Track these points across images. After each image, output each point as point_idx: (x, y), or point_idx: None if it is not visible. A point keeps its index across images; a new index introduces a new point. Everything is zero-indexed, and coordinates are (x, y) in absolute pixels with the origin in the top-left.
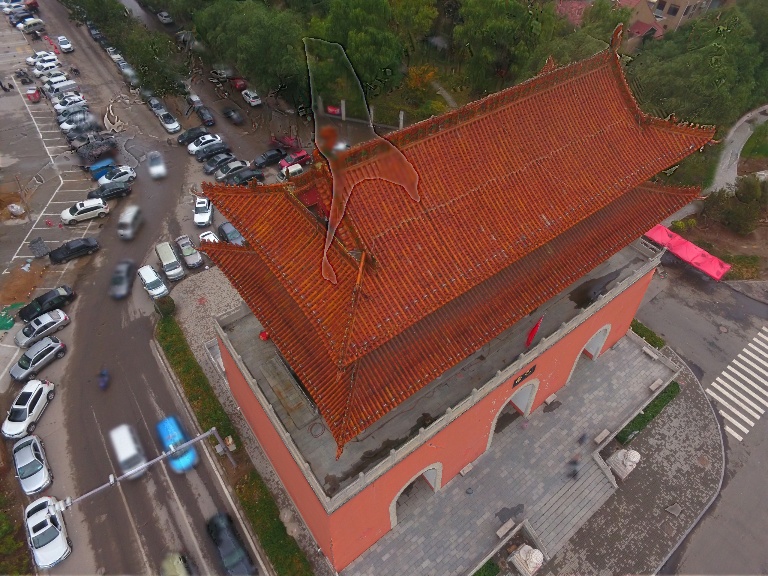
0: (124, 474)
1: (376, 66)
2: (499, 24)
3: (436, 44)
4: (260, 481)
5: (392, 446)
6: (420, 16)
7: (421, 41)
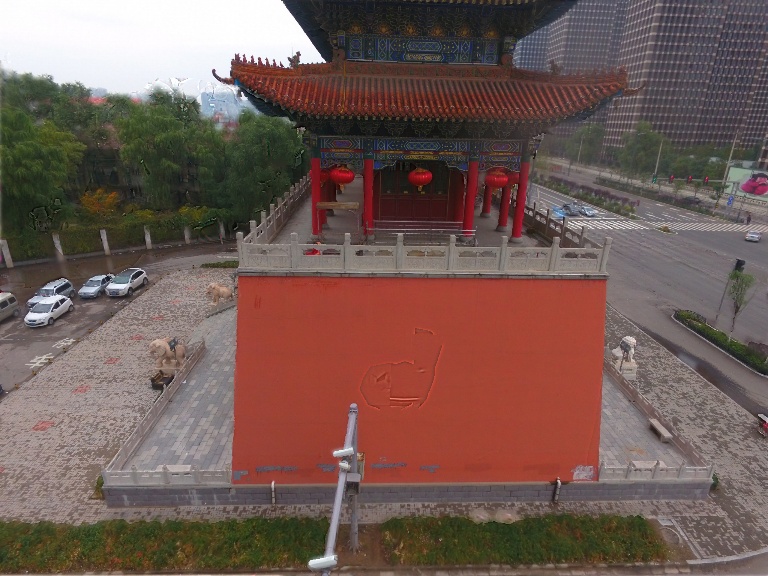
0: (326, 544)
1: (49, 183)
2: (173, 133)
3: (101, 170)
4: (410, 519)
5: (543, 245)
6: (66, 149)
7: (70, 181)
